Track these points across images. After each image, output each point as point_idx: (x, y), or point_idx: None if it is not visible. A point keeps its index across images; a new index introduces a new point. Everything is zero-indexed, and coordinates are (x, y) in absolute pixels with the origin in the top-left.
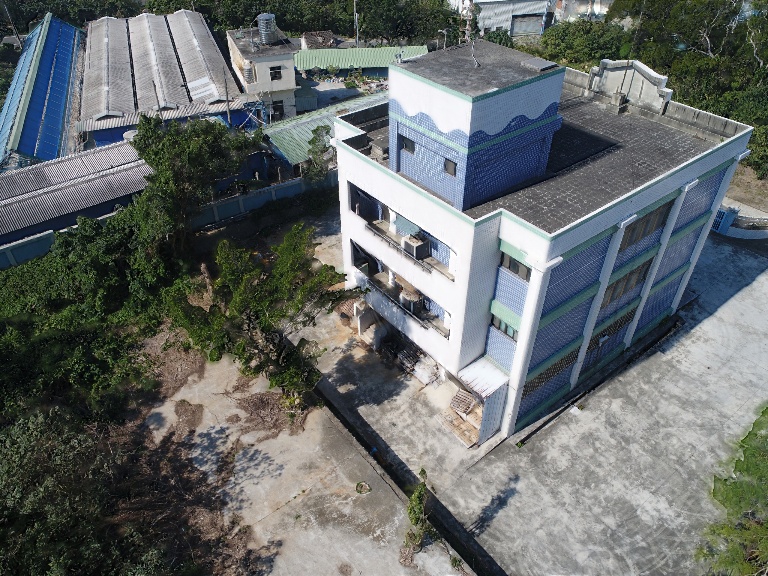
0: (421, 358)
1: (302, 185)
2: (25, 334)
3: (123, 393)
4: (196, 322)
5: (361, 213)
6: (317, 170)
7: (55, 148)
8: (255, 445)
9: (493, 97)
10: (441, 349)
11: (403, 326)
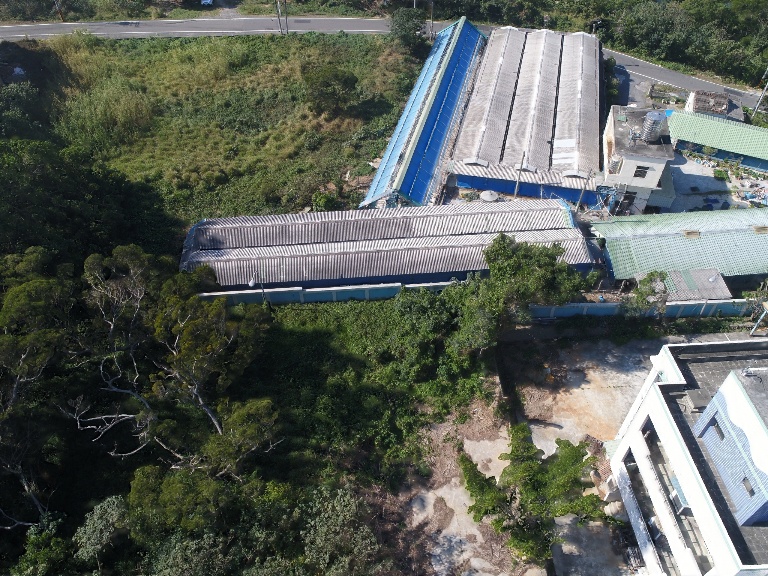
0: None
1: (616, 309)
2: (358, 376)
3: (405, 469)
4: (475, 487)
5: (649, 435)
6: (636, 304)
7: (426, 187)
8: (479, 573)
9: None
10: None
11: (642, 545)
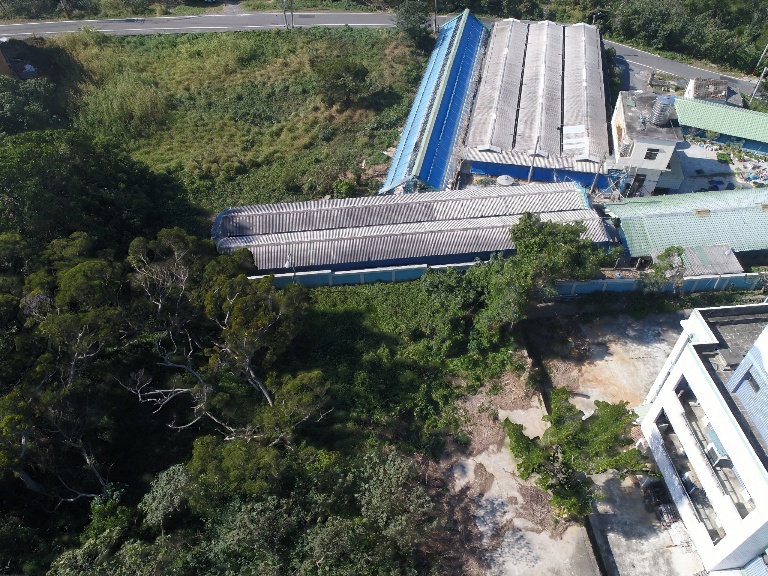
0: (681, 523)
1: (634, 285)
2: (392, 353)
3: (444, 438)
4: (521, 447)
5: (682, 395)
6: (654, 279)
7: (442, 173)
8: (522, 531)
9: None
10: (704, 544)
11: (677, 499)
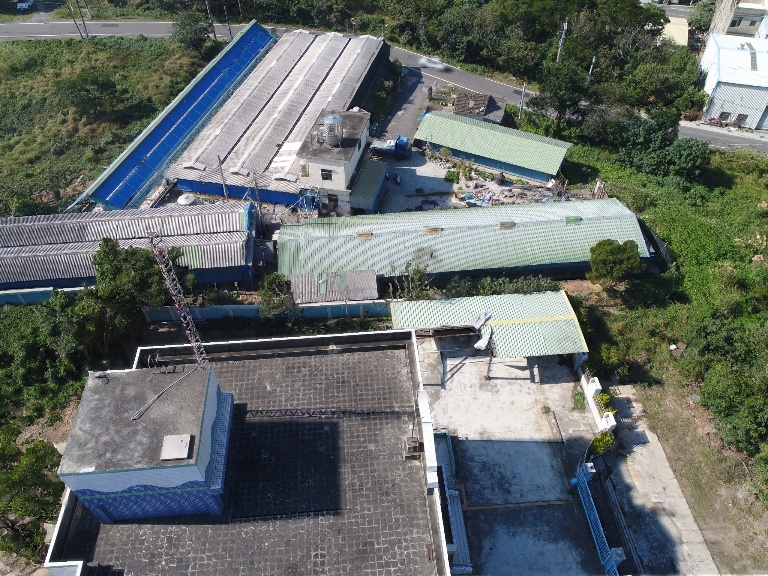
0: None
1: None
2: None
3: None
4: None
5: None
6: None
7: (134, 191)
8: None
9: (89, 475)
10: None
11: None
